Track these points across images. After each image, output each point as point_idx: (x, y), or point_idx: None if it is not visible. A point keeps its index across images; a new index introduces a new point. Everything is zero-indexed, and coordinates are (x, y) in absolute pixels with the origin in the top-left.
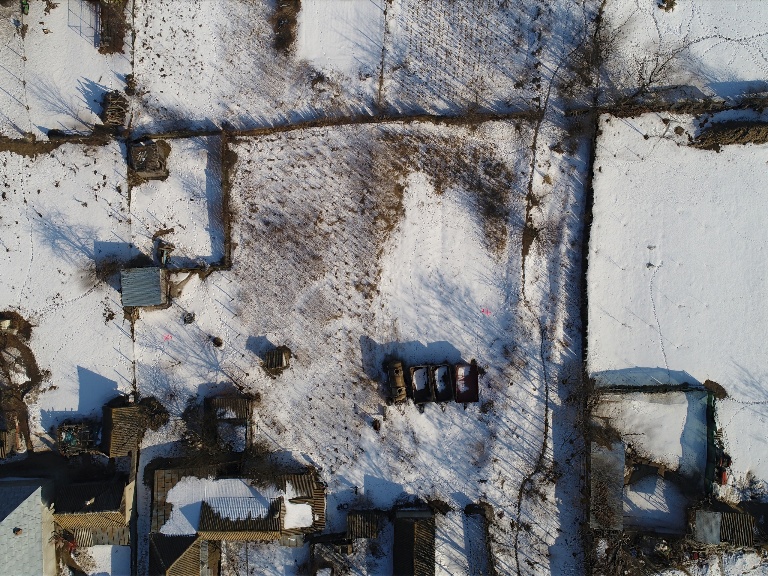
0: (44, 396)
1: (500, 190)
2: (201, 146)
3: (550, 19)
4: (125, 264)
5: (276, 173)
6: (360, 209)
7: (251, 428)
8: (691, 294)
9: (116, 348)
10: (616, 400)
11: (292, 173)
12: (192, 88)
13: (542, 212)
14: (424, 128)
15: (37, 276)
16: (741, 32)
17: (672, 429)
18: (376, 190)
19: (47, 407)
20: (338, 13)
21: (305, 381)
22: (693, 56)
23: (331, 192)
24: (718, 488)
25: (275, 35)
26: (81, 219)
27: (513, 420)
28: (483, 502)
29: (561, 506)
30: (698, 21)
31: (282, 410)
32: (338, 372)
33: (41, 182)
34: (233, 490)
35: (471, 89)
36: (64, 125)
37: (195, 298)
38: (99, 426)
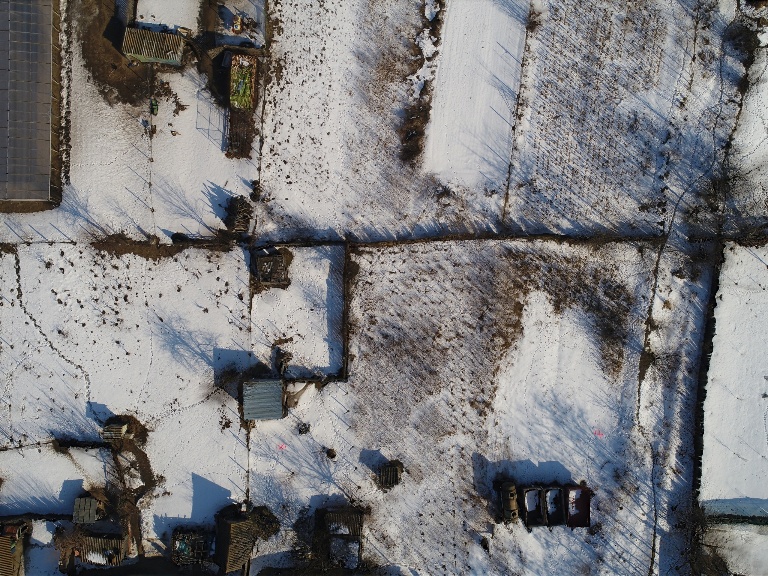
0: (157, 501)
1: (619, 312)
2: (324, 256)
3: (679, 143)
4: (243, 372)
5: (397, 286)
6: (479, 326)
7: None
8: None
9: (231, 456)
10: (724, 529)
11: (413, 287)
12: (317, 196)
13: (660, 337)
14: (547, 247)
15: (155, 381)
16: None
17: None
18: (496, 307)
19: (160, 513)
20: (466, 126)
21: (416, 496)
22: None
23: (451, 307)
24: None
25: (402, 146)
26: (201, 325)
27: (620, 544)
28: None
29: None
30: None
31: (392, 525)
32: (449, 489)
33: (163, 286)
34: None
35: (596, 209)
36: (188, 229)
37: (311, 408)
38: (213, 536)
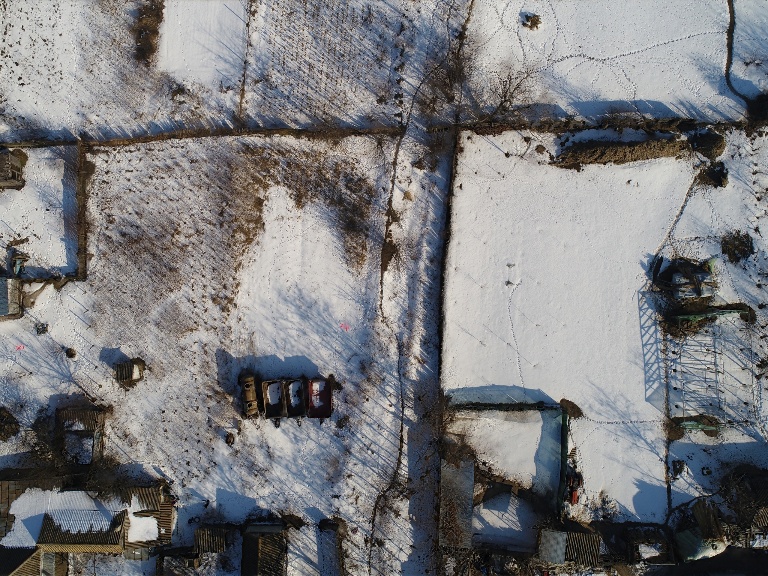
0: None
1: (361, 205)
2: (58, 156)
3: (413, 35)
4: None
5: (134, 184)
6: (219, 222)
7: (102, 440)
8: (549, 313)
9: None
10: (472, 417)
11: (150, 185)
12: (51, 97)
13: (402, 228)
14: (285, 142)
15: None
16: (605, 52)
17: (526, 447)
18: (235, 203)
19: None
20: (201, 25)
21: (158, 394)
22: (557, 75)
23: (189, 204)
24: (569, 507)
25: (136, 46)
26: None
27: (368, 436)
28: (337, 517)
29: (415, 523)
30: (562, 40)
31: (134, 422)
32: (192, 385)
33: None
34: (77, 502)
35: (333, 103)
36: None
37: (49, 308)
38: None
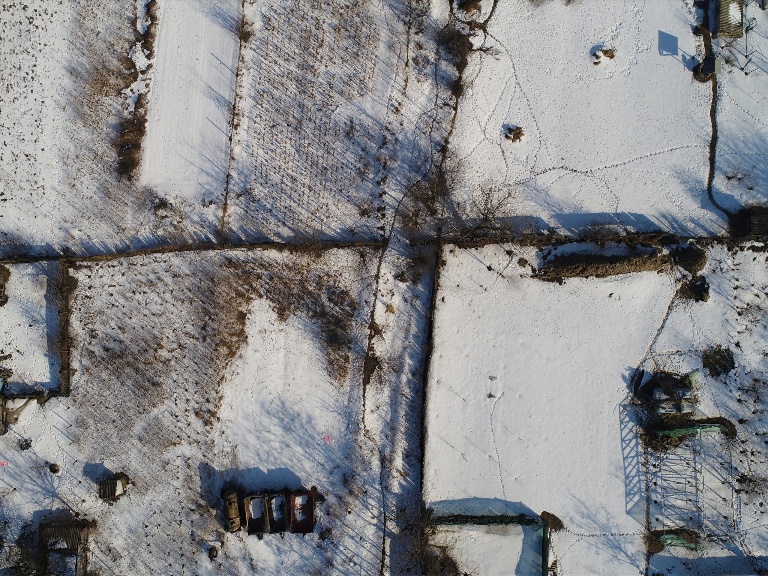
0: None
1: (344, 318)
2: (40, 272)
3: (396, 148)
4: None
5: (117, 299)
6: (201, 336)
7: (86, 555)
8: (530, 426)
9: None
10: (453, 530)
11: (133, 299)
12: (33, 212)
13: (385, 341)
14: (267, 255)
15: None
16: (587, 164)
17: (508, 560)
18: (218, 317)
19: None
20: (183, 138)
21: (142, 508)
22: (539, 187)
23: (172, 319)
24: None
25: (119, 159)
26: None
27: (351, 548)
28: None
29: None
30: (545, 152)
31: (118, 537)
32: (176, 499)
33: None
34: None
35: (316, 216)
36: None
37: (32, 424)
38: None
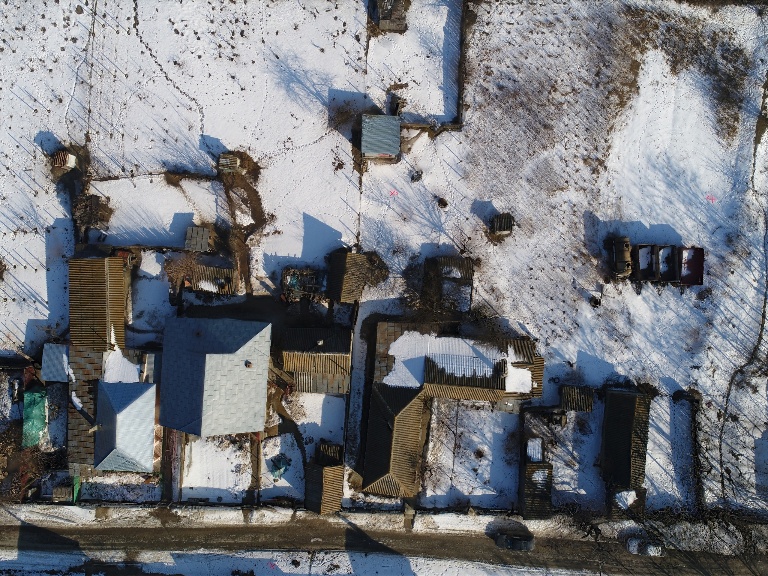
0: (267, 240)
1: (736, 76)
2: (442, 2)
3: None
4: (358, 114)
5: (514, 37)
6: (595, 82)
7: None
8: None
9: (343, 198)
10: None
11: (530, 39)
12: None
13: None
14: (666, 6)
15: (269, 118)
16: None
17: None
18: (612, 64)
19: (270, 251)
20: None
21: (527, 250)
22: None
23: (568, 62)
24: None
25: None
26: (317, 65)
27: (730, 309)
28: (693, 389)
29: None
30: None
31: (502, 277)
32: (560, 244)
33: (280, 23)
34: (456, 348)
35: None
36: None
37: (423, 156)
38: (324, 273)
